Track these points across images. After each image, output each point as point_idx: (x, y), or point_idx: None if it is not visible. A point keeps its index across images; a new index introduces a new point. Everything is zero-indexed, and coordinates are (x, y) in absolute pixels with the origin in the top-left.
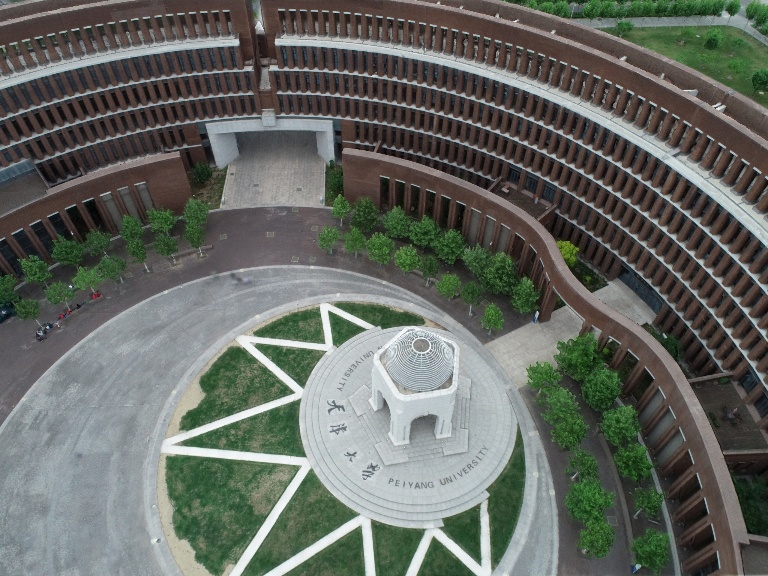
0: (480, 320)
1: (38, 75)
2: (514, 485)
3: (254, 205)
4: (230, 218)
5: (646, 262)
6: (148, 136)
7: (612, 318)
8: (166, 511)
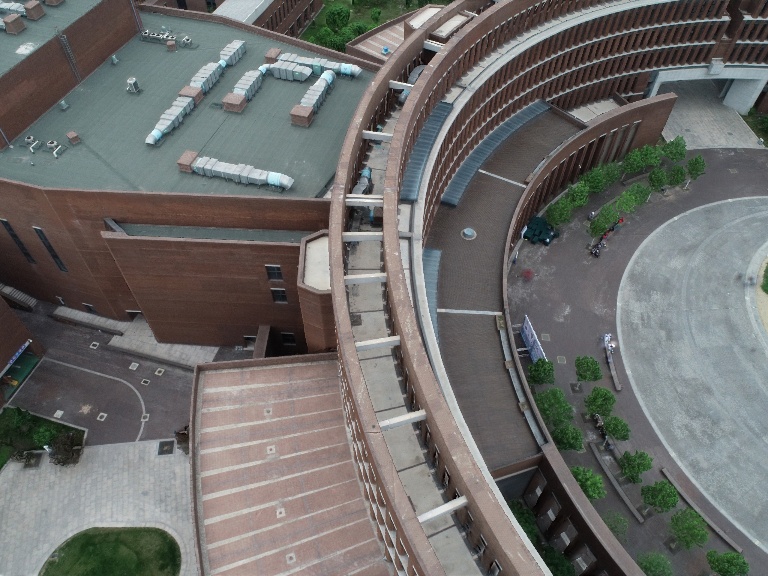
0: None
1: (584, 19)
2: None
3: (700, 147)
4: (686, 157)
5: None
6: None
7: None
8: None
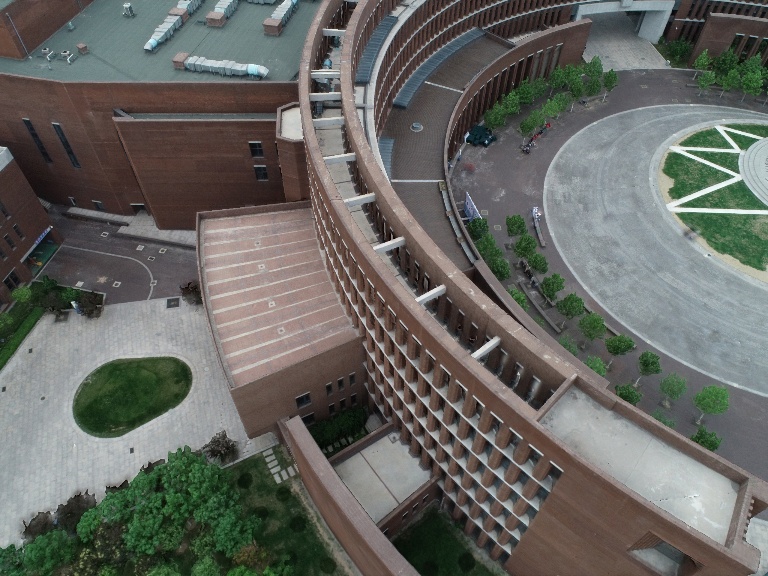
0: None
1: None
2: None
3: (617, 69)
4: None
5: None
6: (539, 15)
7: None
8: (700, 241)
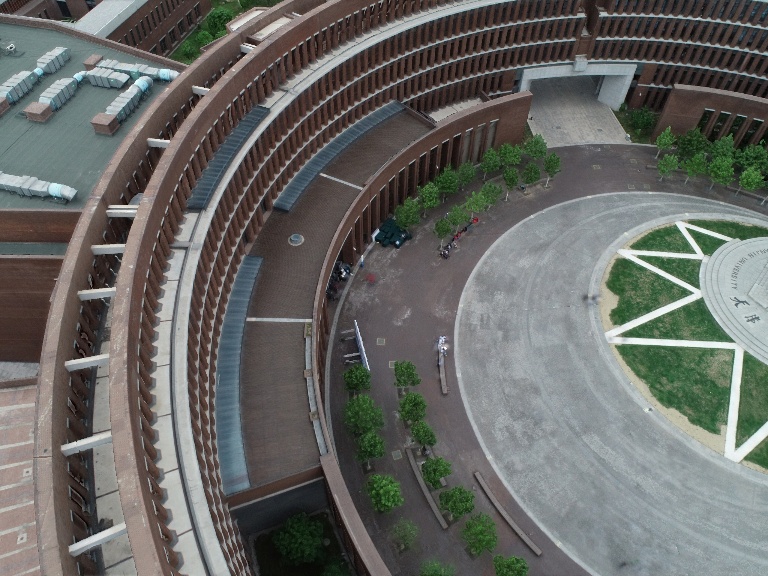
0: None
1: (429, 19)
2: None
3: (568, 144)
4: None
5: None
6: (476, 82)
7: None
8: (642, 387)
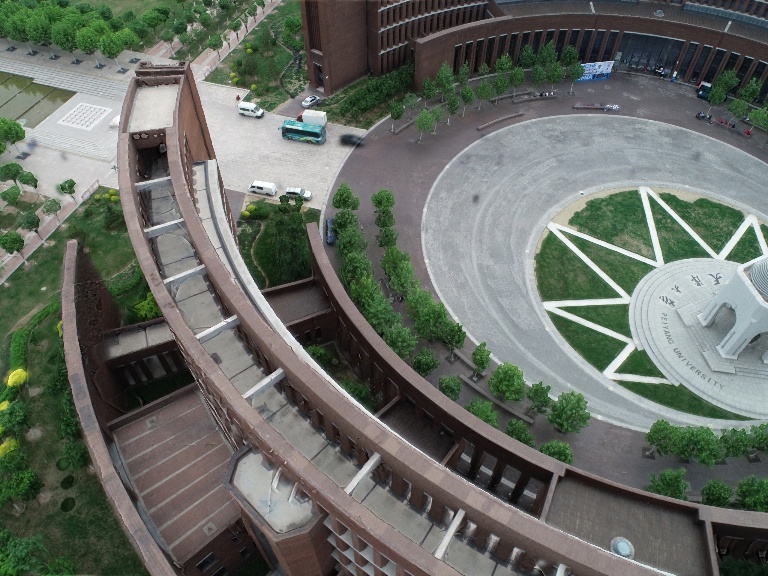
0: None
1: None
2: (693, 406)
3: None
4: None
5: None
6: None
7: None
8: (601, 195)
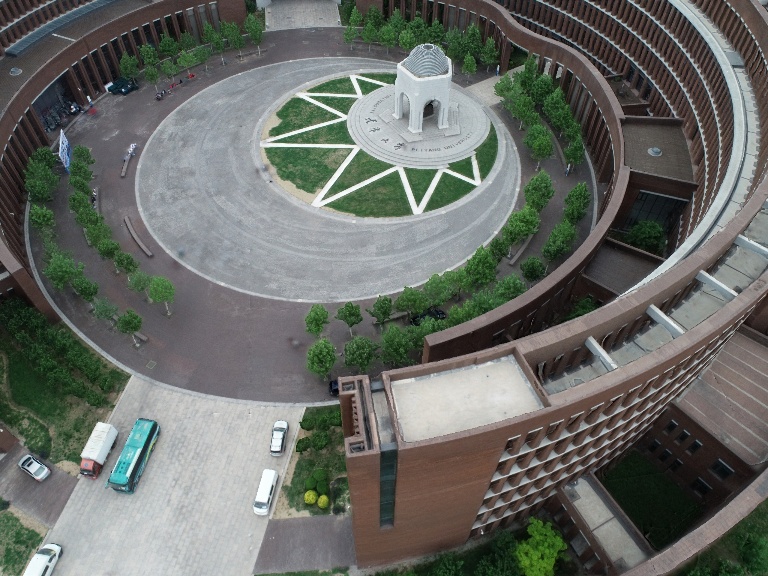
0: (460, 77)
1: None
2: (491, 147)
3: (290, 28)
4: (275, 35)
5: (567, 26)
6: None
7: (545, 40)
8: (272, 170)
